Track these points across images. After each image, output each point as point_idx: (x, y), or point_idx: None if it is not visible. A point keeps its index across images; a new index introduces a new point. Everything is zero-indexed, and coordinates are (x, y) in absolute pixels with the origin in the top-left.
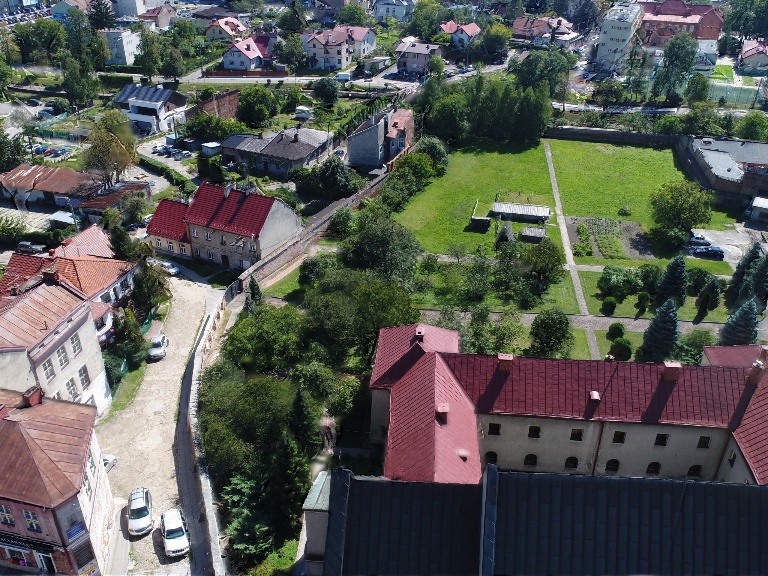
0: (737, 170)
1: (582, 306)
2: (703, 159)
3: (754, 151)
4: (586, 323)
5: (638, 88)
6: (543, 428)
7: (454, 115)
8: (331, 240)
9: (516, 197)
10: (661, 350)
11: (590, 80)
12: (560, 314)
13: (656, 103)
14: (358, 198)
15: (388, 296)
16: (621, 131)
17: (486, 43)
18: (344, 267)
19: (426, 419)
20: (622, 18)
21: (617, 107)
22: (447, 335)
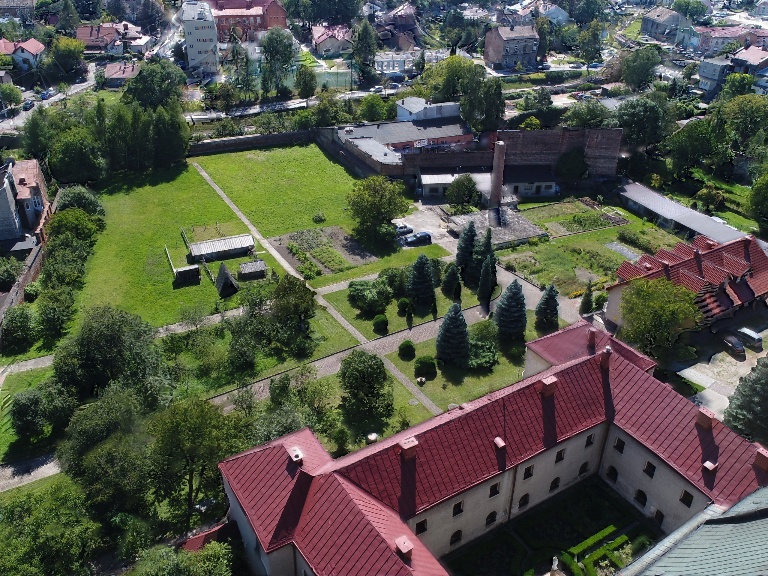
0: (391, 153)
1: (355, 334)
2: (358, 149)
3: (390, 131)
4: (372, 351)
5: (249, 87)
6: (465, 500)
7: (86, 154)
8: (40, 361)
9: (203, 232)
10: (460, 354)
11: (204, 87)
12: (374, 358)
13: (269, 99)
14: (20, 288)
15: (200, 417)
16: (263, 135)
17: (58, 60)
18: (76, 390)
19: (389, 568)
20: (202, 17)
21: (236, 109)
22: (306, 439)
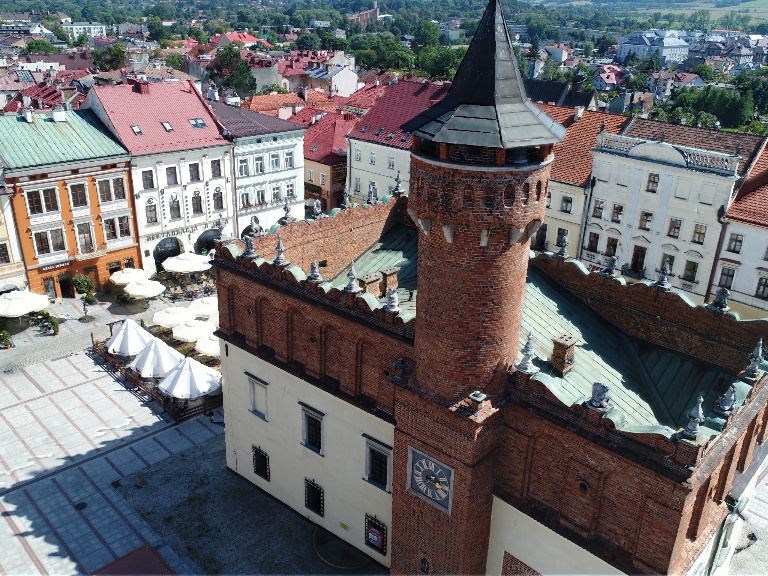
0: None
1: None
2: None
3: None
4: None
5: None
6: None
7: (683, 102)
8: None
9: None
10: None
11: None
12: None
13: None
14: None
15: None
16: None
17: None
18: None
19: None
20: None
21: None
22: None
